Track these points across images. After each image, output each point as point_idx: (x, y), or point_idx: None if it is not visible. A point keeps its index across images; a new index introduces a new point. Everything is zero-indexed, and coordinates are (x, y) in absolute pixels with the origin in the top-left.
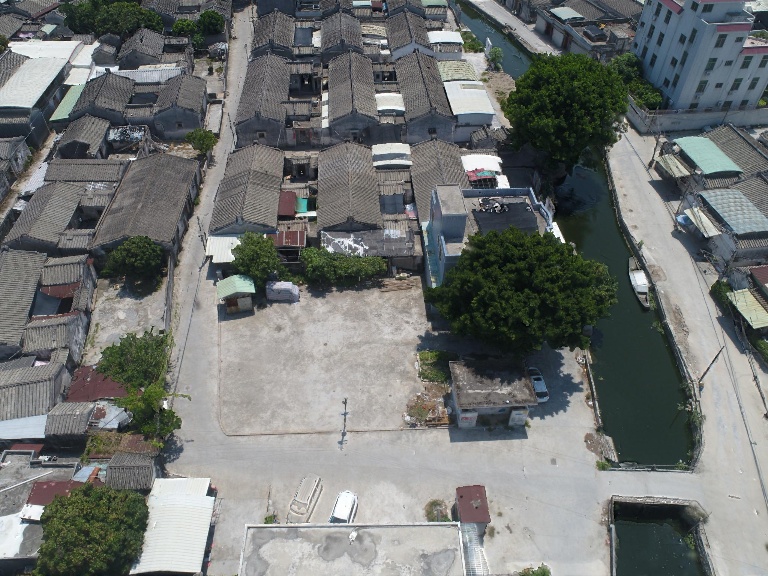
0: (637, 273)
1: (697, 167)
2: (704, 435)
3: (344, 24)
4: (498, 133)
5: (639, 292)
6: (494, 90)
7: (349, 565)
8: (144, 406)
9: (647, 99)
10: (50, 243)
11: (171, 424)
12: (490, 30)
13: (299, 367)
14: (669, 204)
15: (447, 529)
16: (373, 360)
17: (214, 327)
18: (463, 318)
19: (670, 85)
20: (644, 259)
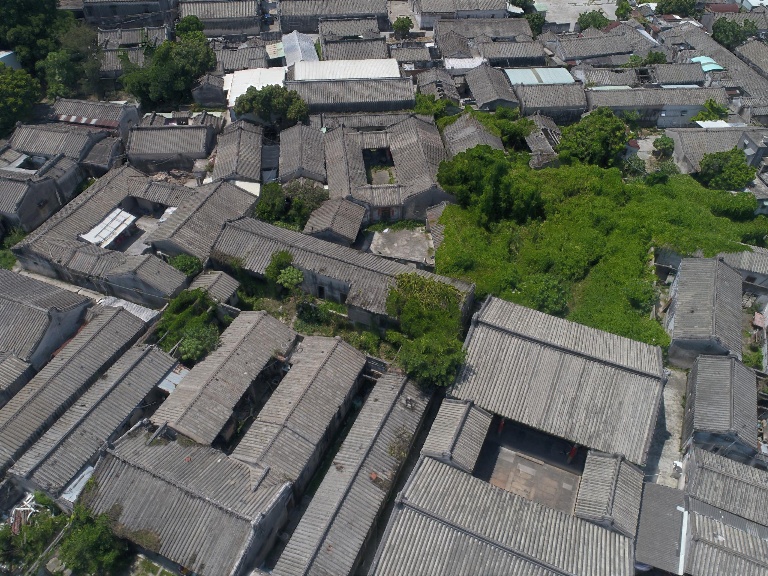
0: None
1: None
2: None
3: None
4: None
5: None
6: None
7: None
8: (627, 1)
9: None
10: None
11: None
12: None
13: (567, 8)
14: None
15: None
16: None
17: None
18: None
19: None
20: None
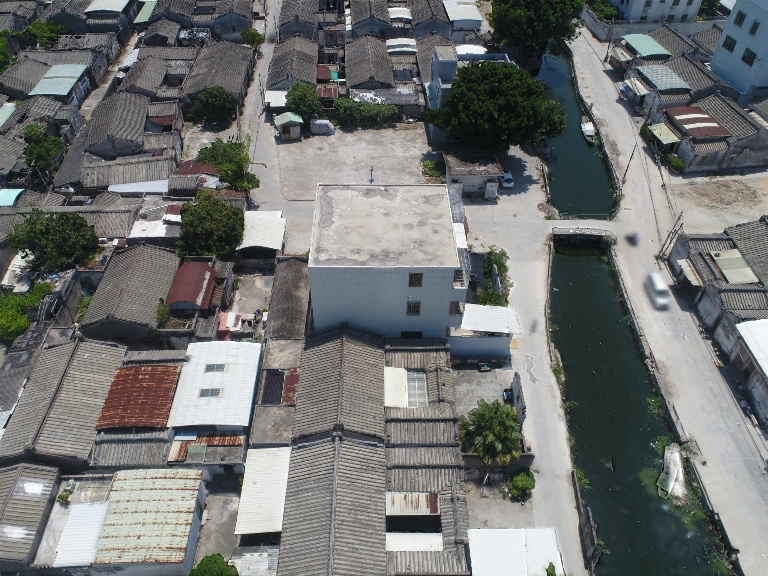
0: (587, 124)
1: (637, 53)
2: (622, 205)
3: None
4: (485, 36)
5: (587, 135)
6: (484, 13)
7: (380, 199)
8: (236, 168)
9: (606, 13)
10: (151, 92)
11: (254, 182)
12: None
13: (336, 168)
14: (617, 84)
15: (439, 187)
16: (389, 165)
17: (273, 147)
18: (453, 121)
19: (625, 2)
20: (593, 115)
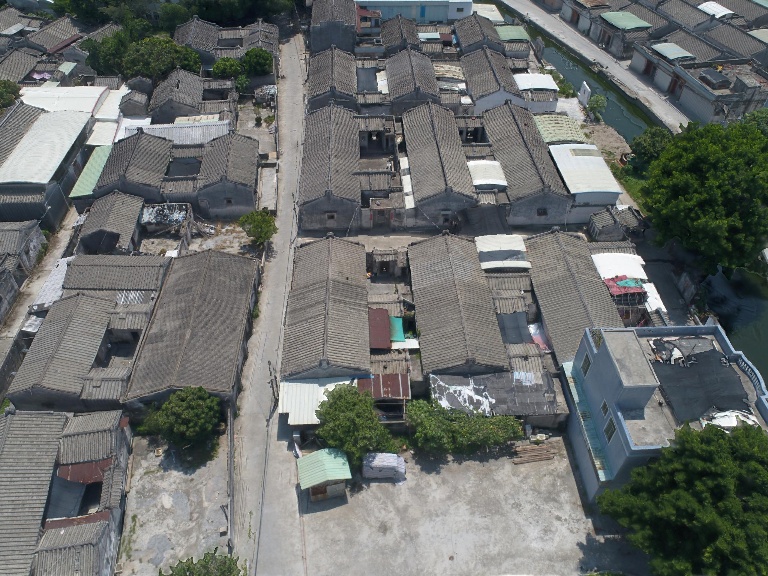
0: None
1: None
2: None
3: (415, 65)
4: (625, 216)
5: None
6: (599, 149)
7: None
8: None
9: None
10: (71, 394)
11: None
12: (567, 63)
13: None
14: None
15: None
16: None
17: (294, 525)
18: None
19: None
20: None
